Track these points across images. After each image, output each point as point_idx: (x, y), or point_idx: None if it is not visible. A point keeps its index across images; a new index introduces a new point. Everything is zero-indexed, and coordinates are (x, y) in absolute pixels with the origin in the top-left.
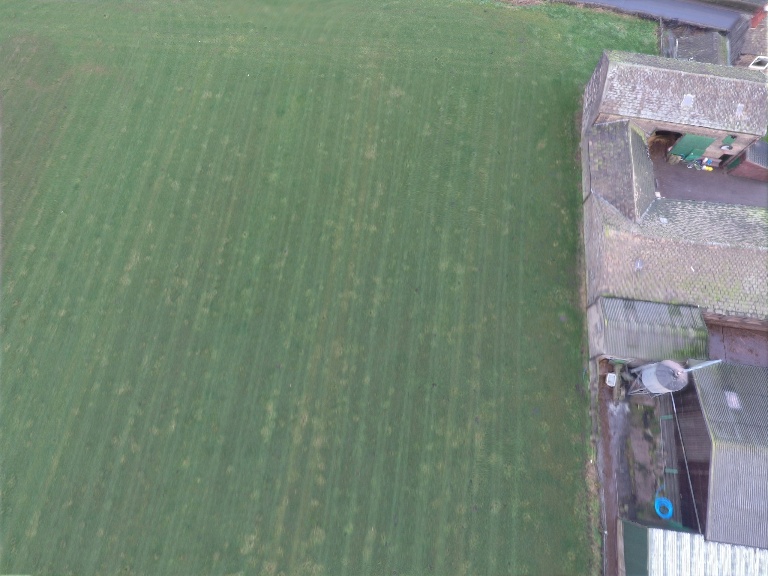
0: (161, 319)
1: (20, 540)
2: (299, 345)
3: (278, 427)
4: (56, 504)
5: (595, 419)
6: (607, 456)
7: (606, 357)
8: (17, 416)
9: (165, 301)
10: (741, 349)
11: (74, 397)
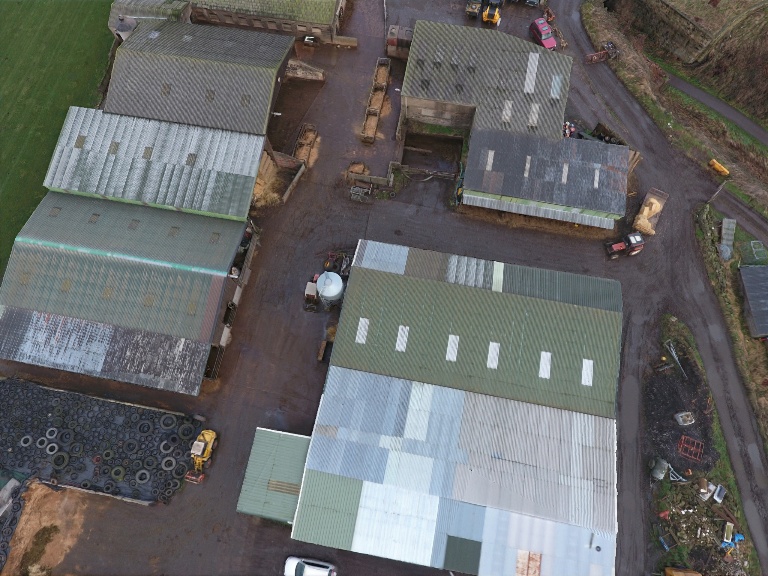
0: None
1: None
2: None
3: None
4: None
5: None
6: None
7: (115, 32)
8: None
9: None
10: None
11: None
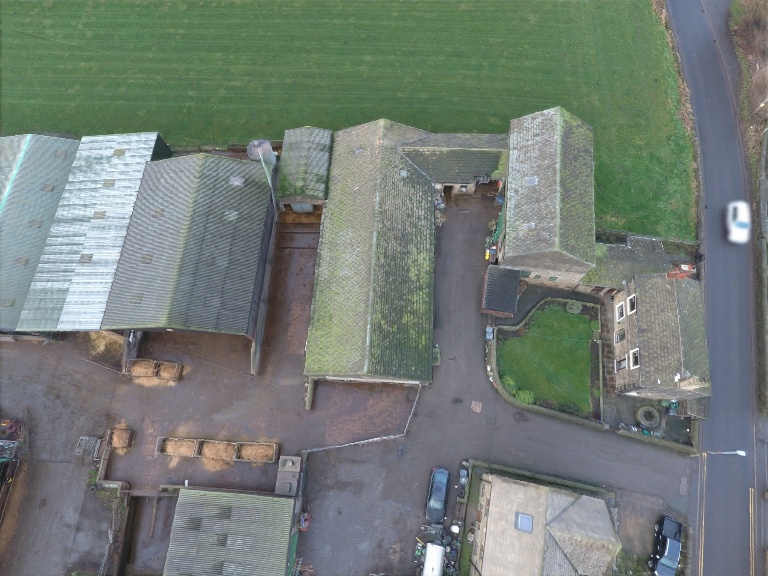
0: None
1: None
2: None
3: None
4: None
5: None
6: None
7: None
8: None
9: None
10: (302, 262)
11: None
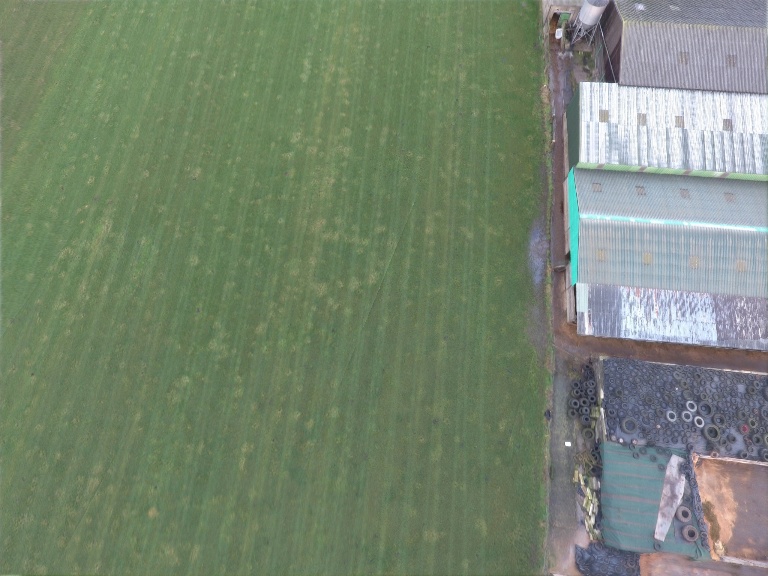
0: (219, 14)
1: (127, 140)
2: (325, 26)
3: (313, 73)
4: (151, 119)
5: (547, 56)
6: (556, 82)
7: (554, 11)
8: (115, 72)
9: (221, 3)
10: None
11: (157, 60)
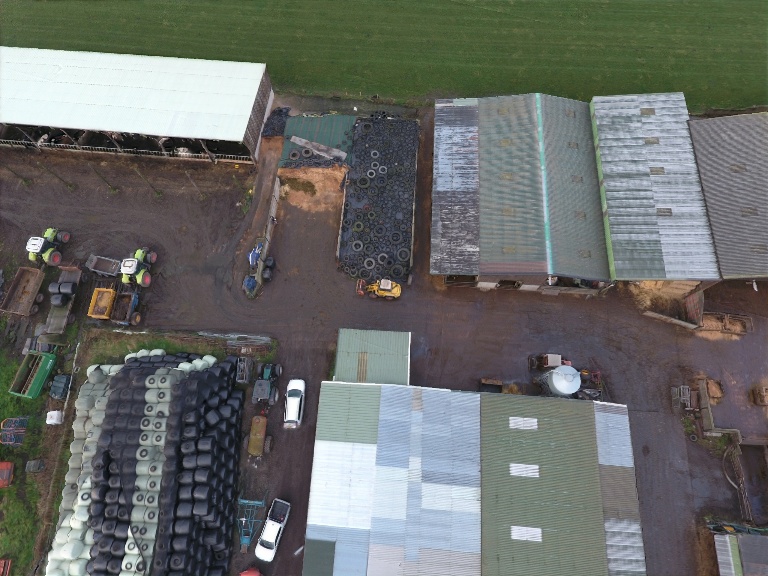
0: None
1: None
2: None
3: None
4: None
5: None
6: None
7: None
8: None
9: None
10: None
11: None
